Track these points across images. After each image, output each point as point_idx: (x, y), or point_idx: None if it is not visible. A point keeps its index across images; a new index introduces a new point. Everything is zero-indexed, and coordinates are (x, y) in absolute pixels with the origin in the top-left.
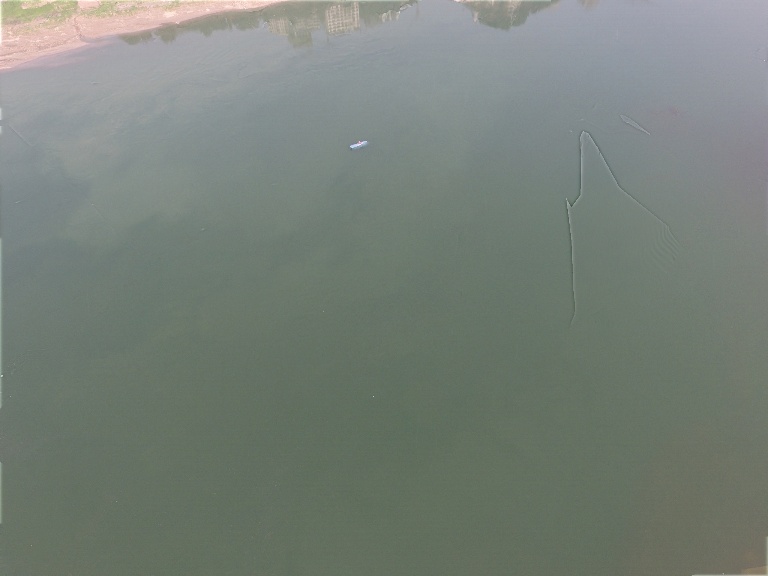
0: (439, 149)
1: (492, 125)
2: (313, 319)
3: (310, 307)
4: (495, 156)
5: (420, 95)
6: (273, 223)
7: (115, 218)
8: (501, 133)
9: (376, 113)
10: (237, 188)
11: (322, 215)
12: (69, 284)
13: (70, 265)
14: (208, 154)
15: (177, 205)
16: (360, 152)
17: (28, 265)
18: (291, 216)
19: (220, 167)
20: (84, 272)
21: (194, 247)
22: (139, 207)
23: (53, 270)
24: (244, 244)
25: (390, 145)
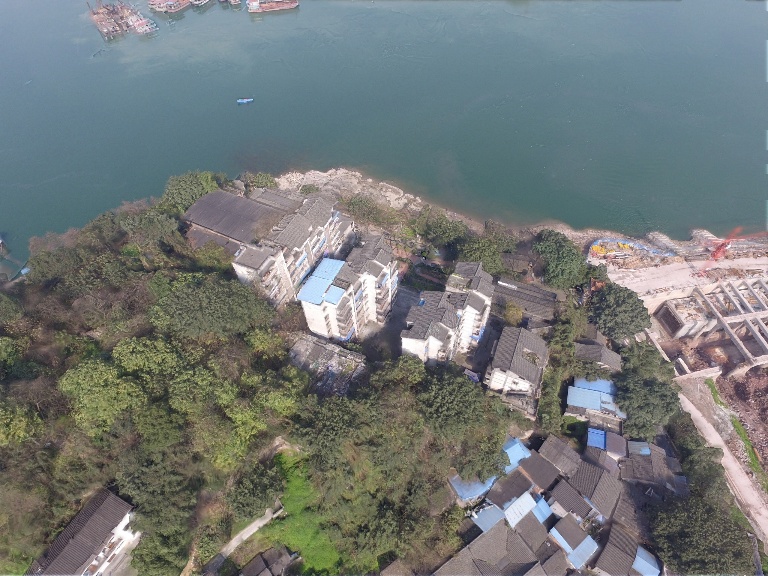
0: None
1: None
2: None
3: None
4: None
5: None
6: (760, 53)
7: (648, 51)
8: None
9: None
10: (714, 38)
11: None
12: None
13: (660, 66)
14: (670, 23)
15: (687, 44)
16: None
17: (638, 65)
18: None
19: (688, 29)
20: (673, 69)
21: (722, 62)
22: (660, 46)
23: (655, 67)
24: (754, 61)
25: None
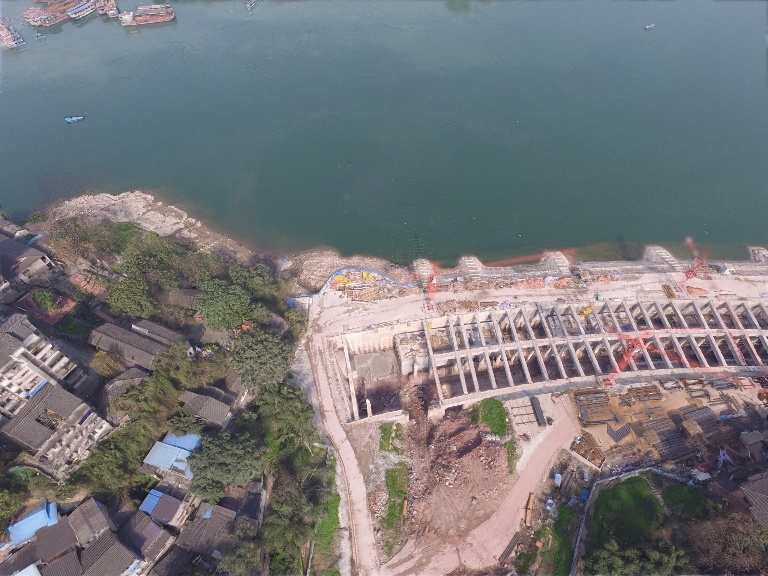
0: (715, 25)
1: (743, 14)
2: (687, 101)
3: (680, 97)
4: (753, 31)
5: (662, 6)
6: (618, 65)
7: (507, 64)
8: (750, 19)
9: (637, 16)
10: (578, 49)
11: (651, 60)
12: (517, 87)
13: None
14: (541, 34)
15: (547, 56)
16: (650, 31)
17: (484, 79)
18: (628, 61)
19: (556, 40)
20: (519, 83)
21: (575, 75)
22: (520, 58)
23: (501, 82)
24: (608, 74)
25: (674, 25)
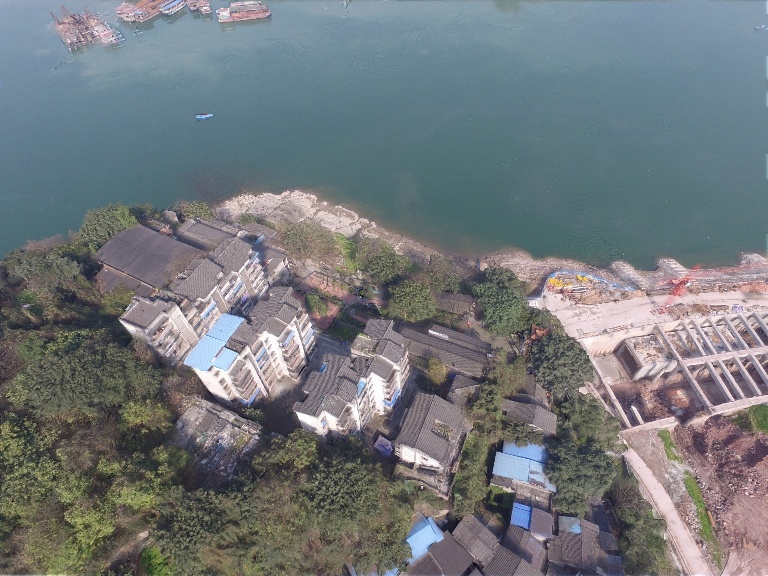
0: None
1: None
2: None
3: None
4: None
5: (759, 6)
6: (741, 65)
7: (626, 63)
8: None
9: (737, 16)
10: (695, 49)
11: None
12: (651, 87)
13: (637, 80)
14: (651, 33)
15: (666, 56)
16: (761, 32)
17: (614, 78)
18: (751, 61)
19: (668, 39)
20: (650, 83)
21: (702, 75)
22: (639, 58)
23: (631, 81)
24: (735, 74)
25: None
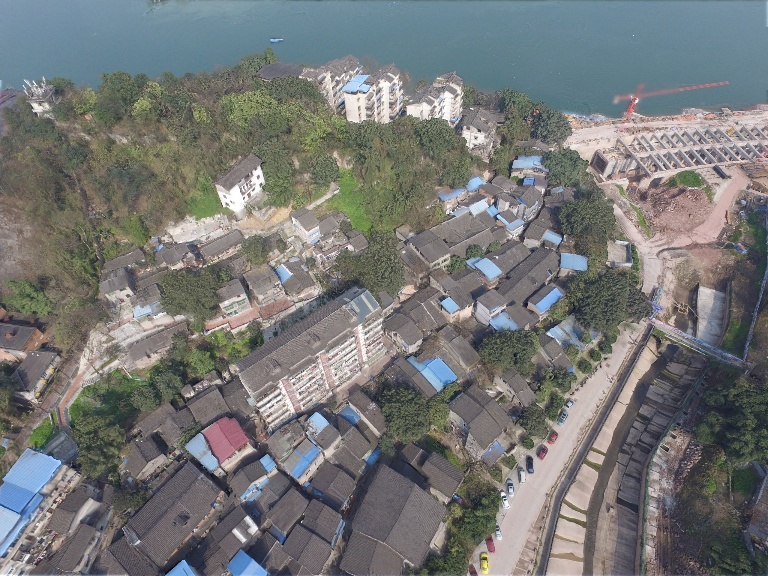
0: None
1: None
2: None
3: (756, 19)
4: None
5: None
6: (698, 1)
7: (607, 2)
8: None
9: None
10: None
11: None
12: None
13: None
14: None
15: None
16: None
17: None
18: None
19: None
20: None
21: (666, 8)
22: None
23: (609, 11)
24: (692, 6)
25: None
